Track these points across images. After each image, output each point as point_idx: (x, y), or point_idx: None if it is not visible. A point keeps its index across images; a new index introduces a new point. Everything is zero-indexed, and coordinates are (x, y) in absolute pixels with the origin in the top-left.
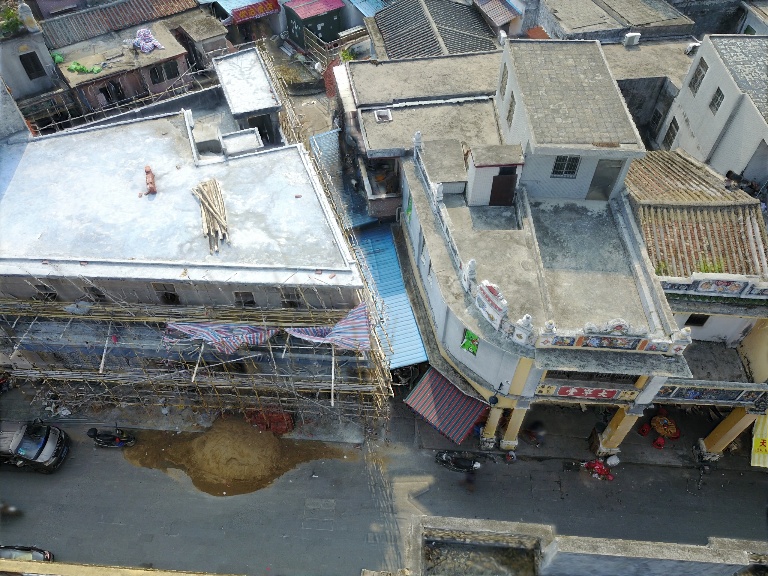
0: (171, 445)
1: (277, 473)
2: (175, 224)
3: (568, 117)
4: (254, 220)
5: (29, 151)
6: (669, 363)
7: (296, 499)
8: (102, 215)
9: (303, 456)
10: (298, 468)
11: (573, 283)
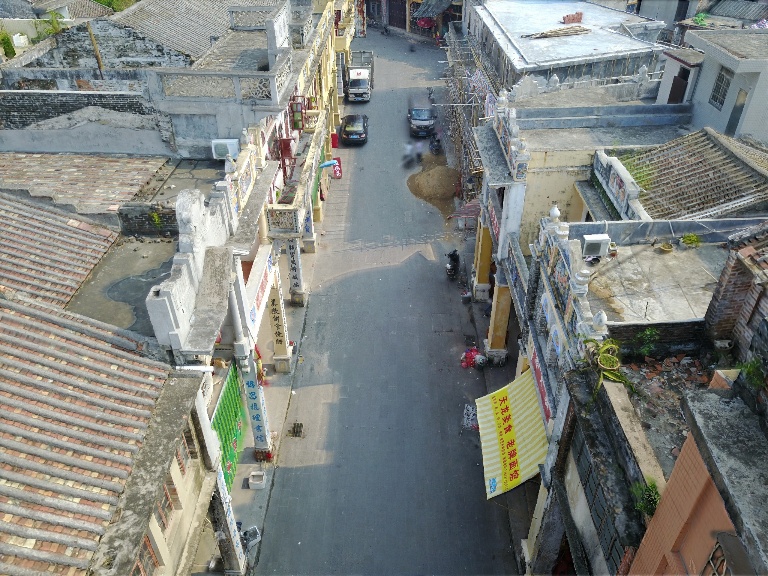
0: (438, 164)
1: (427, 199)
2: (539, 29)
3: (767, 43)
4: (559, 42)
5: (577, 3)
6: (502, 175)
7: (410, 207)
8: (534, 18)
9: (443, 208)
10: (433, 207)
11: (579, 139)
